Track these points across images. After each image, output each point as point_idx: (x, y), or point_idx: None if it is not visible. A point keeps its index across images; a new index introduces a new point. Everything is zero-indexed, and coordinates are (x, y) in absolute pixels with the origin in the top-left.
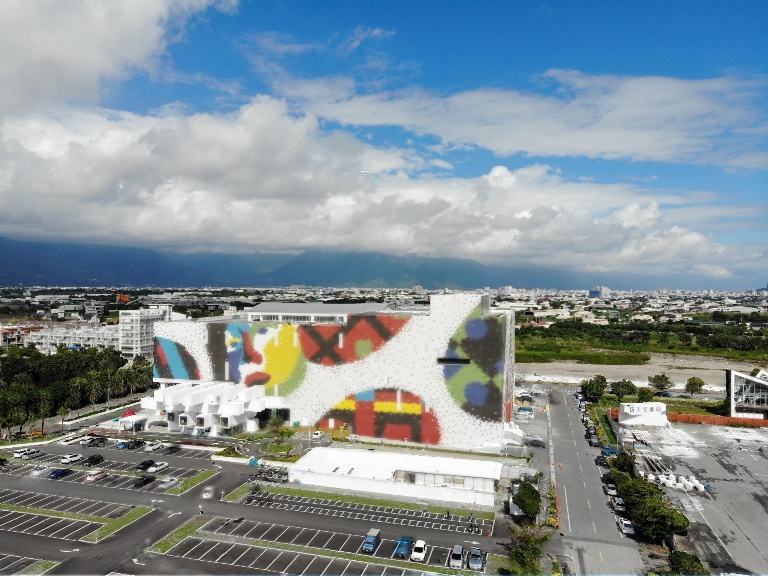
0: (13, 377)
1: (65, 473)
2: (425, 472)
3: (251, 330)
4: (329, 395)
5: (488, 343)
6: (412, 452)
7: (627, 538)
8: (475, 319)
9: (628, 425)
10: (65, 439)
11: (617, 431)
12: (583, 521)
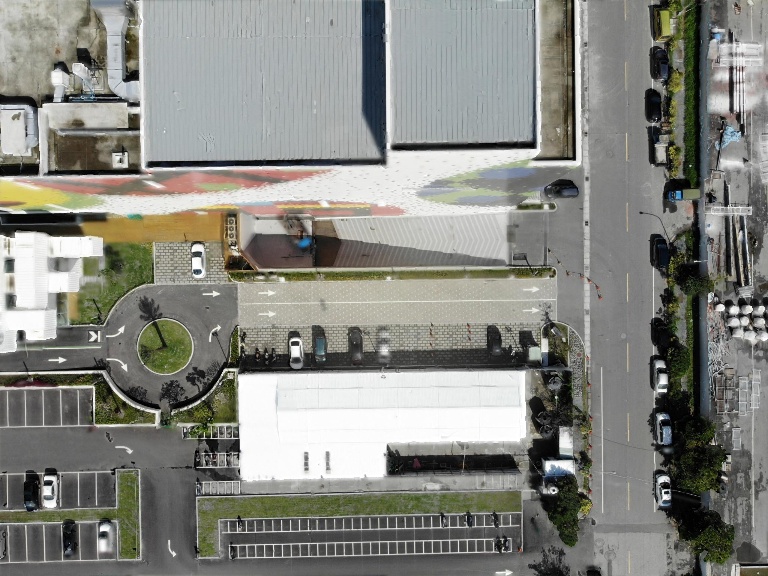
0: None
1: None
2: None
3: None
4: None
5: None
6: (375, 295)
7: (660, 512)
8: (508, 169)
9: None
10: None
11: None
12: (618, 483)
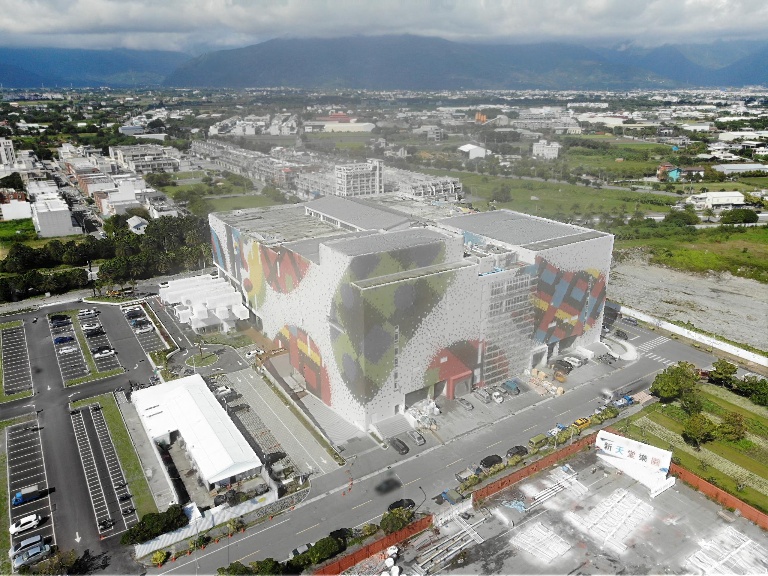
0: (188, 233)
1: (64, 341)
2: (186, 443)
3: (241, 238)
4: (277, 318)
5: (354, 316)
6: (274, 406)
7: None
8: (346, 283)
9: (599, 463)
10: (131, 303)
11: (553, 467)
12: (190, 573)
